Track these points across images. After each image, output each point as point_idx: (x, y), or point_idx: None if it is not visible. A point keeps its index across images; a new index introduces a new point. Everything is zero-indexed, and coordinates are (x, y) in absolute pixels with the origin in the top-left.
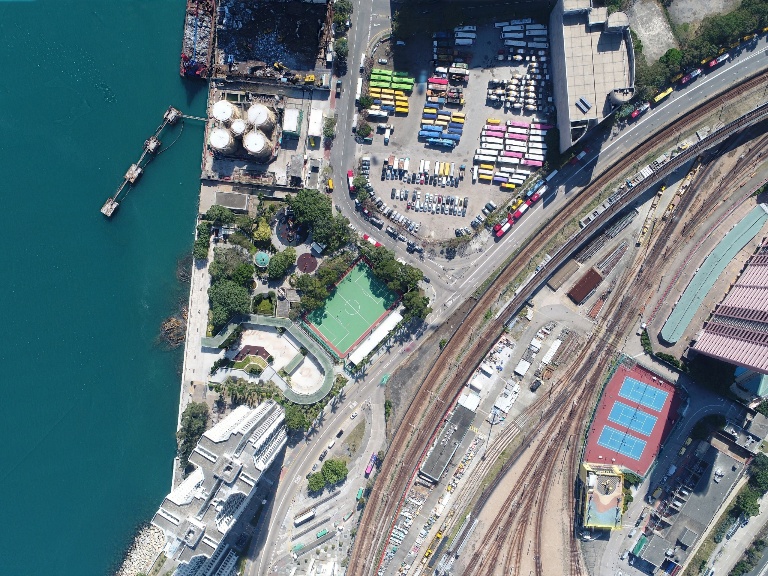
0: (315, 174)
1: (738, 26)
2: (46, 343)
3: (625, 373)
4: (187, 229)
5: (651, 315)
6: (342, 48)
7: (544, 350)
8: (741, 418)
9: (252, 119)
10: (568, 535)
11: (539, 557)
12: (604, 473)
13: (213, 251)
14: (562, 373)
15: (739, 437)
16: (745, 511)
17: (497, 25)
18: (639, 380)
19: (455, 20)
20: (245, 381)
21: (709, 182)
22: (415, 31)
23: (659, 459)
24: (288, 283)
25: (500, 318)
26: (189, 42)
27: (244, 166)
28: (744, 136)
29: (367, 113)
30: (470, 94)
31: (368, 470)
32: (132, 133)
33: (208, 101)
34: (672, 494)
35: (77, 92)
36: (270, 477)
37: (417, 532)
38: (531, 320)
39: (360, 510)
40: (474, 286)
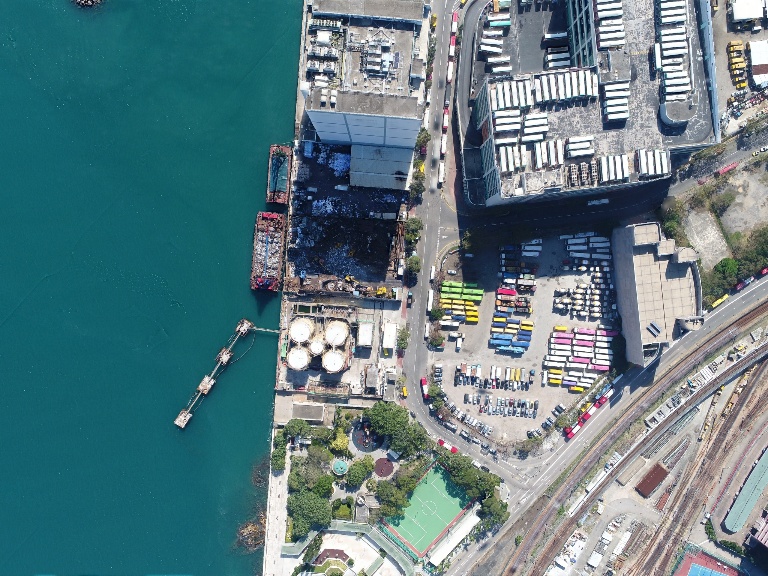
0: (391, 386)
1: None
2: (130, 568)
3: (691, 560)
4: (262, 436)
5: (714, 505)
6: (415, 266)
7: (615, 542)
8: None
9: (330, 340)
10: None
11: None
12: None
13: (290, 459)
14: (632, 562)
15: None
16: None
17: (562, 238)
18: (705, 566)
19: (524, 239)
20: None
21: (763, 379)
22: None
23: None
24: (365, 487)
25: (574, 516)
26: (260, 257)
27: (318, 375)
28: None
29: (440, 326)
30: (537, 302)
31: None
32: (204, 346)
33: None
34: None
35: (154, 320)
36: None
37: None
38: (602, 514)
39: None
40: (546, 484)
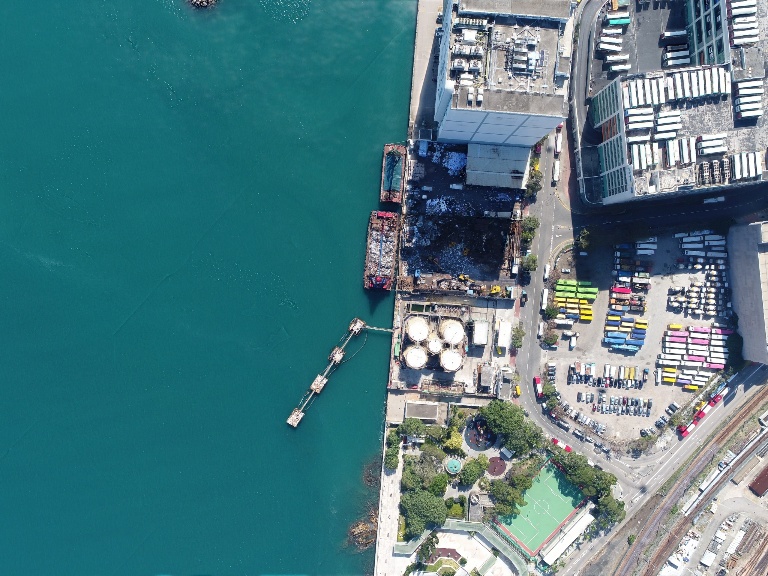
0: (506, 385)
1: None
2: (249, 567)
3: None
4: (373, 435)
5: None
6: (532, 265)
7: (728, 541)
8: None
9: (448, 339)
10: None
11: None
12: None
13: (402, 458)
14: (746, 562)
15: None
16: None
17: (677, 236)
18: None
19: (642, 237)
20: None
21: None
22: None
23: None
24: (478, 486)
25: (689, 515)
26: (374, 257)
27: (431, 374)
28: None
29: (555, 324)
30: (651, 300)
31: None
32: (317, 345)
33: (393, 312)
34: None
35: (274, 319)
36: None
37: None
38: (715, 513)
39: None
40: (659, 483)
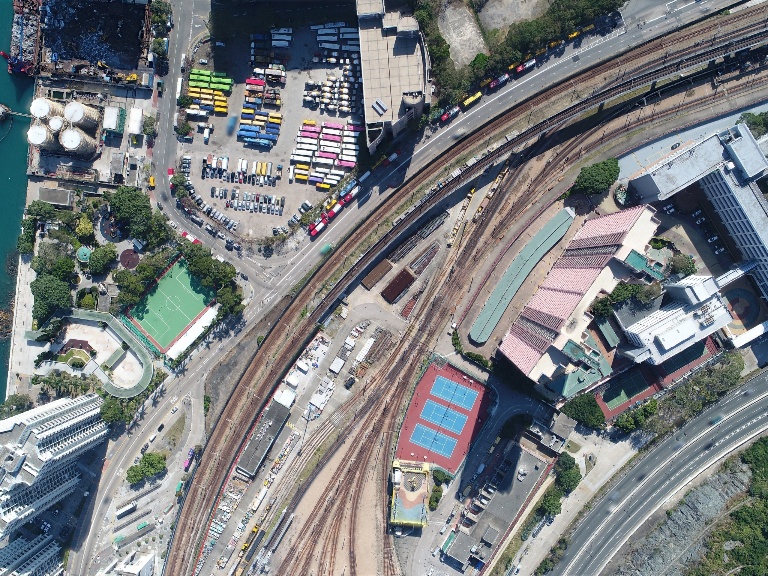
0: (134, 171)
1: (540, 32)
2: None
3: (437, 372)
4: (15, 224)
5: (462, 315)
6: (159, 48)
7: (358, 348)
8: (548, 418)
9: (68, 116)
10: (381, 531)
11: (353, 552)
12: (412, 470)
13: None
14: (376, 371)
15: (544, 437)
16: (547, 509)
17: (312, 28)
18: (450, 379)
19: (267, 22)
20: (68, 374)
21: (518, 185)
22: (234, 33)
23: (470, 457)
24: (111, 278)
25: (313, 316)
26: (16, 40)
27: (69, 163)
28: (552, 140)
29: (185, 112)
30: (288, 95)
31: (185, 464)
32: None
33: (35, 98)
34: (478, 492)
35: None
36: (93, 469)
37: (235, 526)
38: (346, 318)
39: (180, 503)
40: (291, 284)
